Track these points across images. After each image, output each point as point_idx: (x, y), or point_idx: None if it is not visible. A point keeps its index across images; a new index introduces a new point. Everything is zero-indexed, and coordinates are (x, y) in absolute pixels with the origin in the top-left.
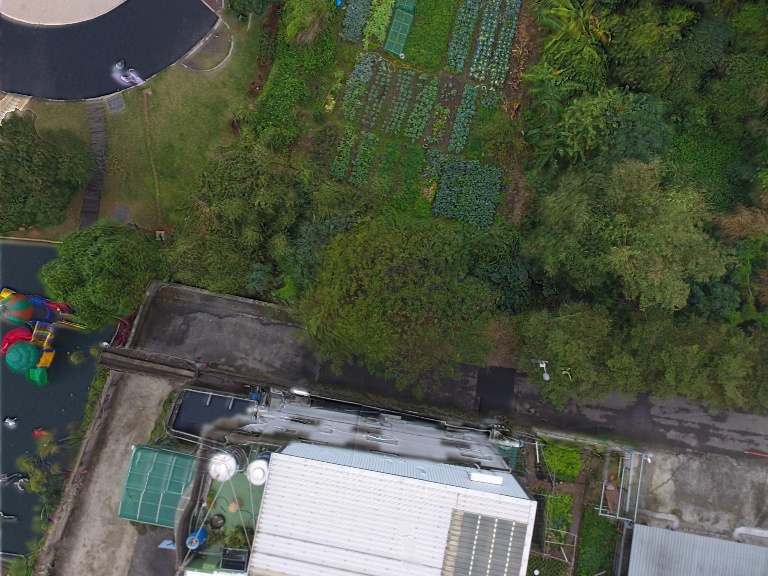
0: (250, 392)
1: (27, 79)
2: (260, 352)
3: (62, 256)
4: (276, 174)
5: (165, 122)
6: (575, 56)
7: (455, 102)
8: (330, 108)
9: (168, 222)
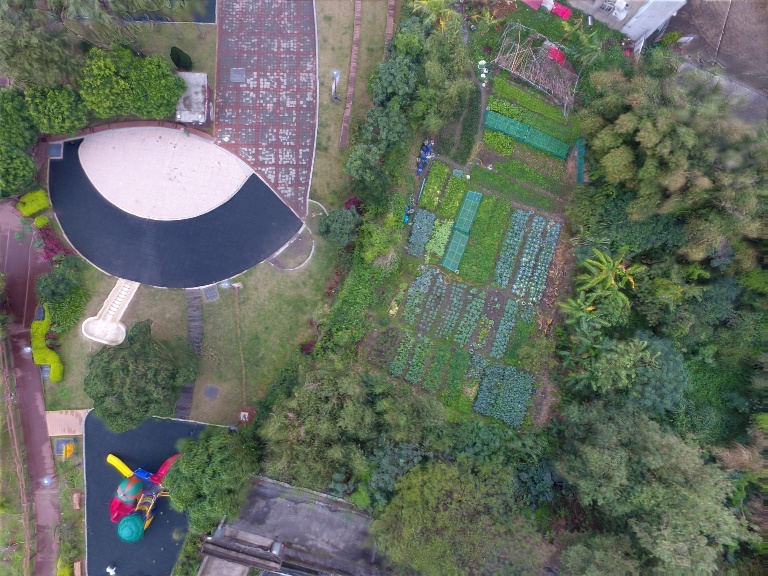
0: (319, 572)
1: (137, 267)
2: (328, 534)
3: (183, 474)
4: (353, 395)
5: (253, 316)
6: (604, 299)
7: (499, 313)
8: (394, 312)
9: (252, 404)
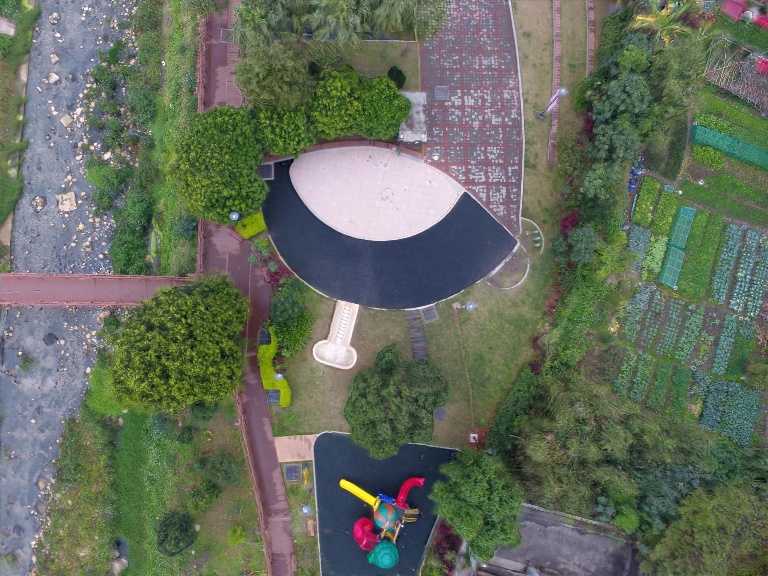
0: None
1: (355, 288)
2: (579, 558)
3: (469, 502)
4: (610, 417)
5: (476, 336)
6: None
7: (717, 329)
8: (615, 330)
9: (480, 426)
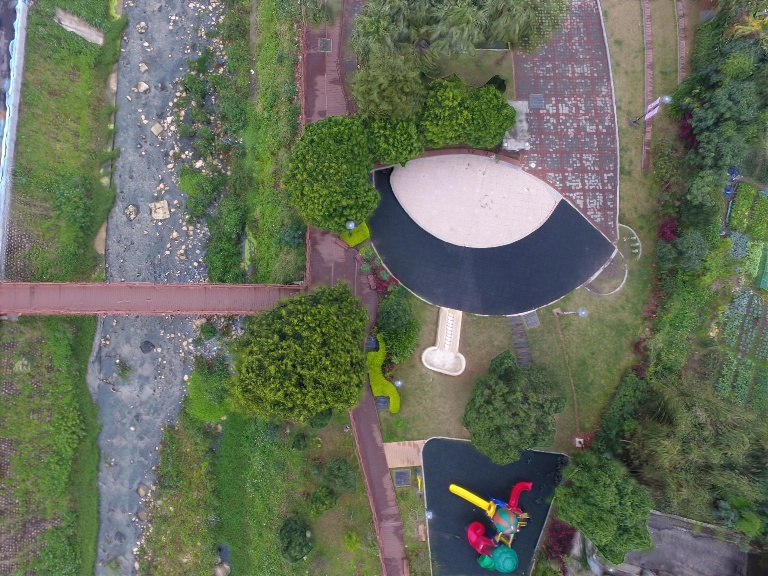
0: None
1: (457, 295)
2: (692, 560)
3: (601, 507)
4: (725, 421)
5: (579, 342)
6: None
7: None
8: (714, 335)
9: (585, 430)
